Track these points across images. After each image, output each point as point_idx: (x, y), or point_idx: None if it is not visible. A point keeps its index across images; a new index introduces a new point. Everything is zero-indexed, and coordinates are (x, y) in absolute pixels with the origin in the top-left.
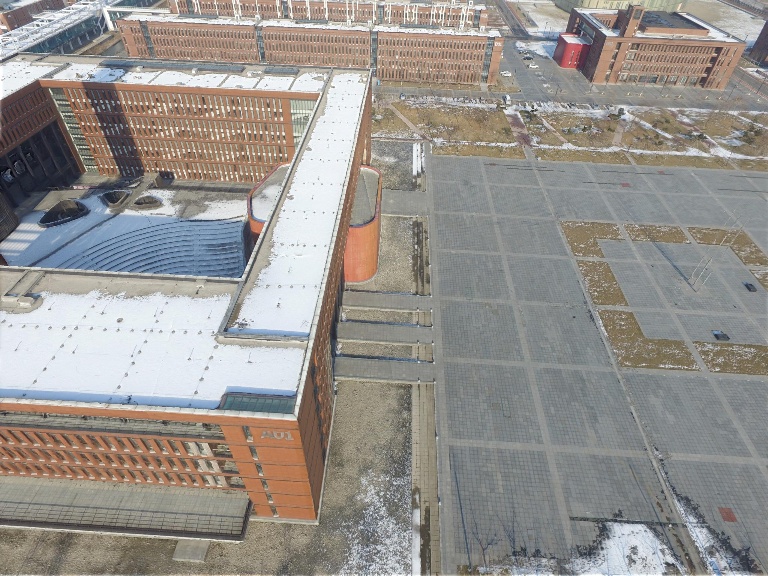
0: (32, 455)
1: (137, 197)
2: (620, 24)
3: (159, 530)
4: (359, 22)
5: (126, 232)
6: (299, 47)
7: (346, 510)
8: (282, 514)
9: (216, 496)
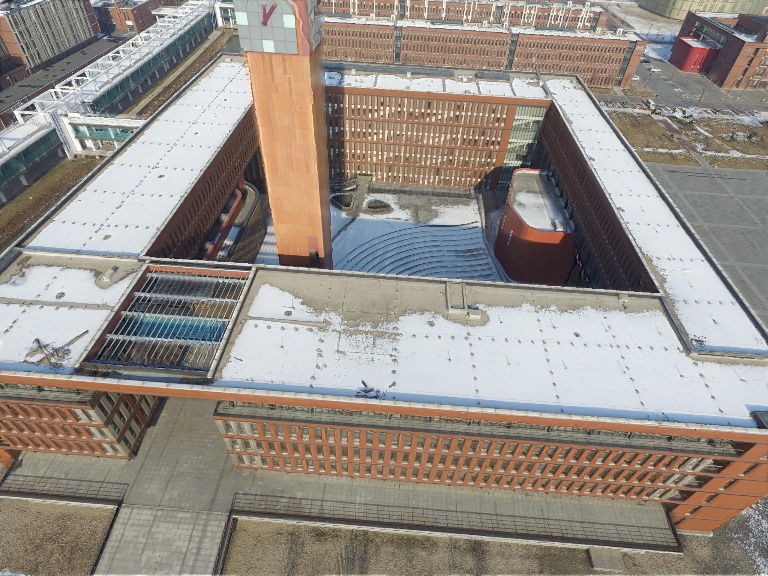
0: (498, 466)
1: (363, 201)
2: (740, 28)
3: (598, 540)
4: (493, 23)
5: (375, 237)
6: (436, 48)
7: (729, 522)
8: (681, 525)
9: (630, 507)
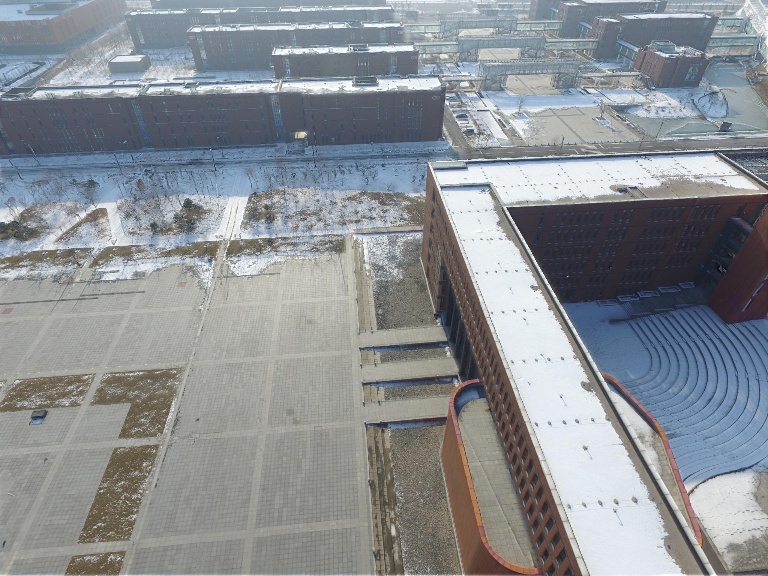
0: None
1: None
2: None
3: None
4: None
5: None
6: None
7: (407, 265)
8: None
9: None
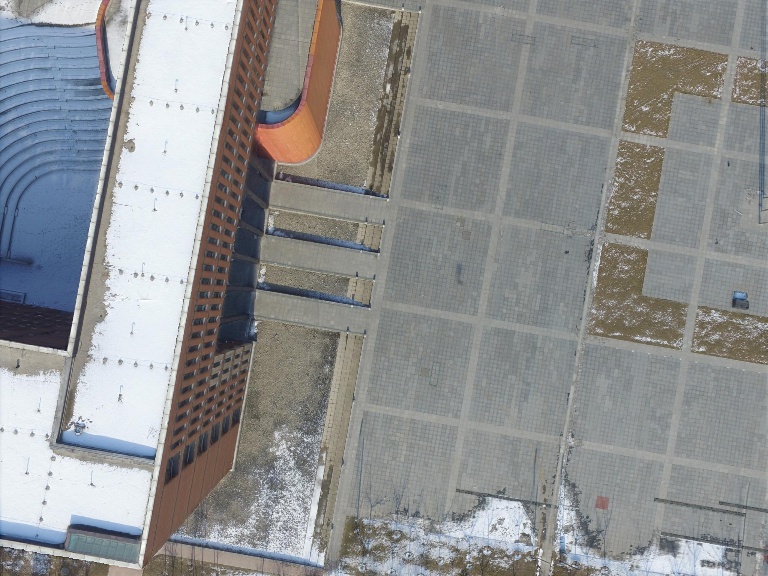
0: None
1: None
2: None
3: None
4: None
5: None
6: None
7: (259, 460)
8: None
9: None
